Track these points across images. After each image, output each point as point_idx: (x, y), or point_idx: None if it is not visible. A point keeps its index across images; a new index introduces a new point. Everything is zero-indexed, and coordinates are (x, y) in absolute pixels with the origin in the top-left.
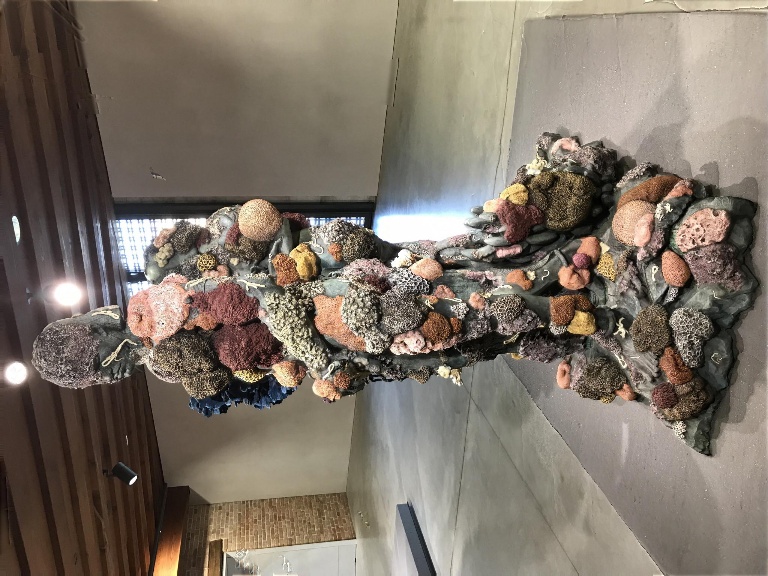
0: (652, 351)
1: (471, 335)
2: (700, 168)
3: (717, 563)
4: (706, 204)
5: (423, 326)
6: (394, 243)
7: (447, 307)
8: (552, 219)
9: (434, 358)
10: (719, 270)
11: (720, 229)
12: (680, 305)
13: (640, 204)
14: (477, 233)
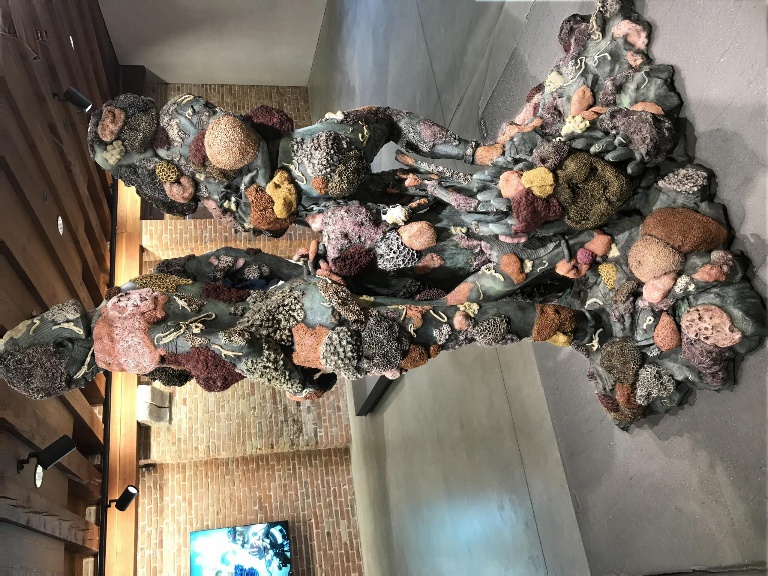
0: (613, 377)
1: None
2: (752, 233)
3: (597, 482)
4: (729, 307)
5: None
6: (391, 113)
7: (430, 331)
8: (571, 218)
9: None
10: (705, 366)
11: (727, 343)
12: None
13: (668, 256)
14: None
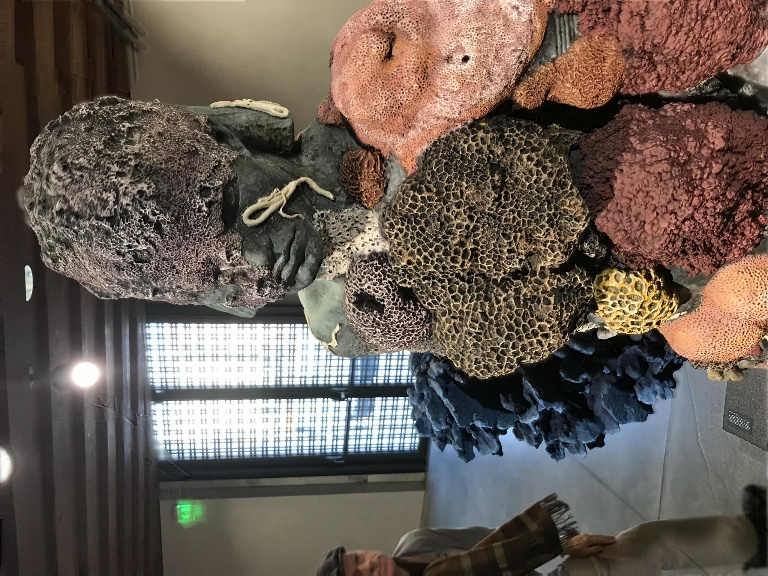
0: None
1: None
2: None
3: None
4: None
5: None
6: None
7: None
8: None
9: None
10: None
11: None
12: None
13: None
14: None
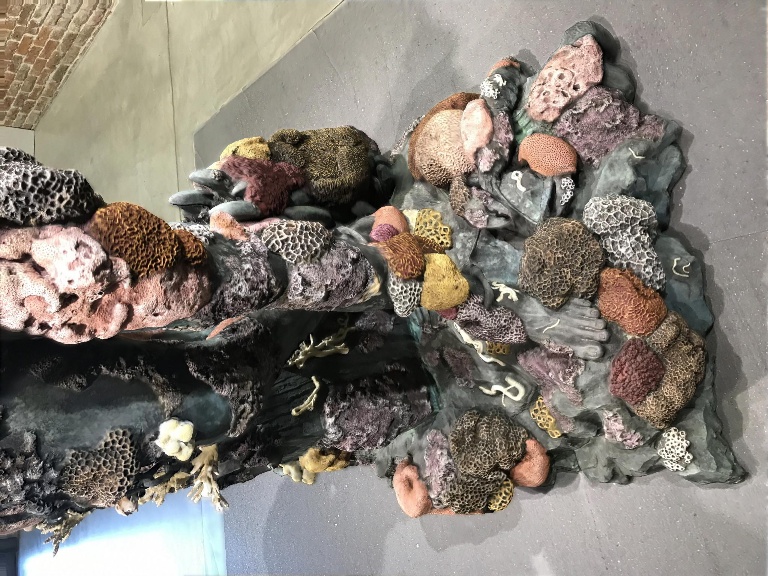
0: (579, 292)
1: (232, 288)
2: None
3: None
4: (551, 54)
5: (93, 218)
6: None
7: None
8: (319, 177)
9: (141, 401)
10: (622, 115)
11: (595, 58)
12: (580, 215)
13: None
14: None
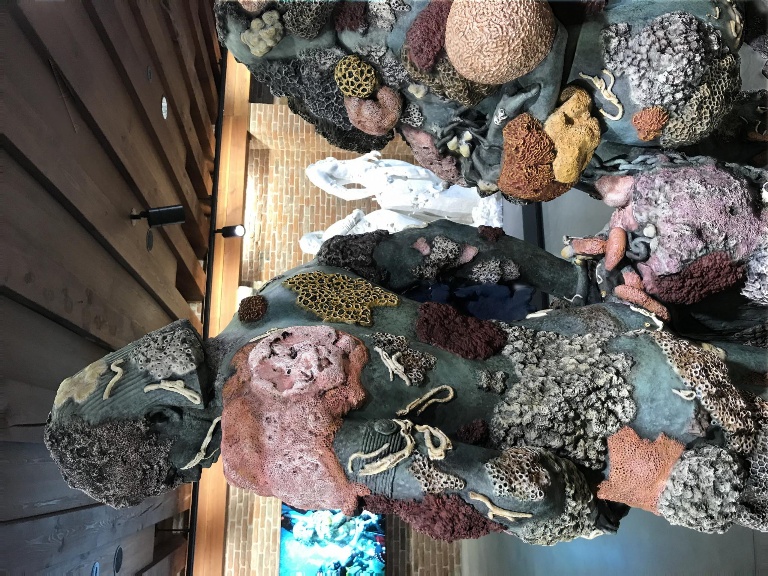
0: None
1: None
2: None
3: None
4: None
5: None
6: None
7: None
8: None
9: None
10: None
11: None
12: None
13: None
14: None
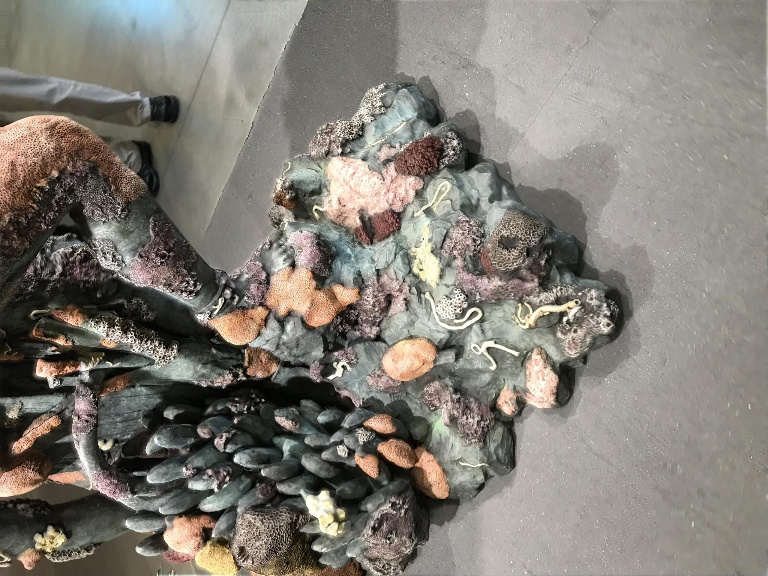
0: None
1: None
2: None
3: None
4: None
5: None
6: (81, 198)
7: None
8: None
9: None
10: None
11: None
12: None
13: None
14: (172, 448)
